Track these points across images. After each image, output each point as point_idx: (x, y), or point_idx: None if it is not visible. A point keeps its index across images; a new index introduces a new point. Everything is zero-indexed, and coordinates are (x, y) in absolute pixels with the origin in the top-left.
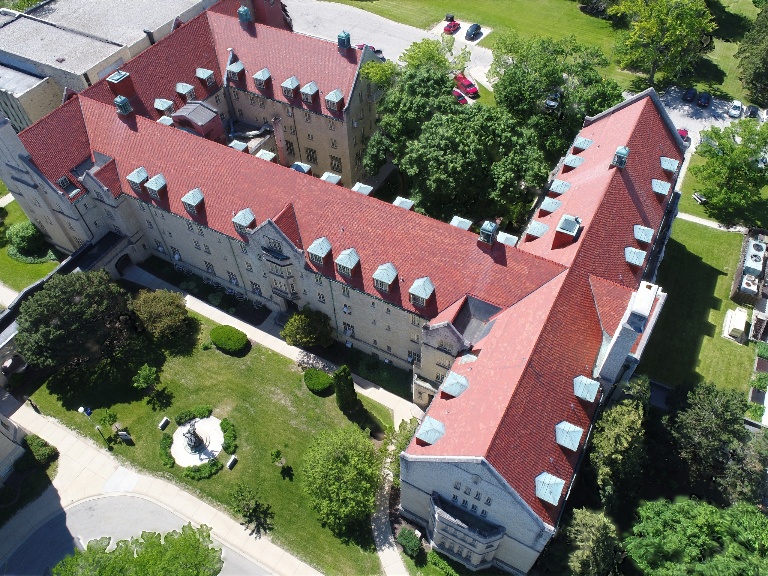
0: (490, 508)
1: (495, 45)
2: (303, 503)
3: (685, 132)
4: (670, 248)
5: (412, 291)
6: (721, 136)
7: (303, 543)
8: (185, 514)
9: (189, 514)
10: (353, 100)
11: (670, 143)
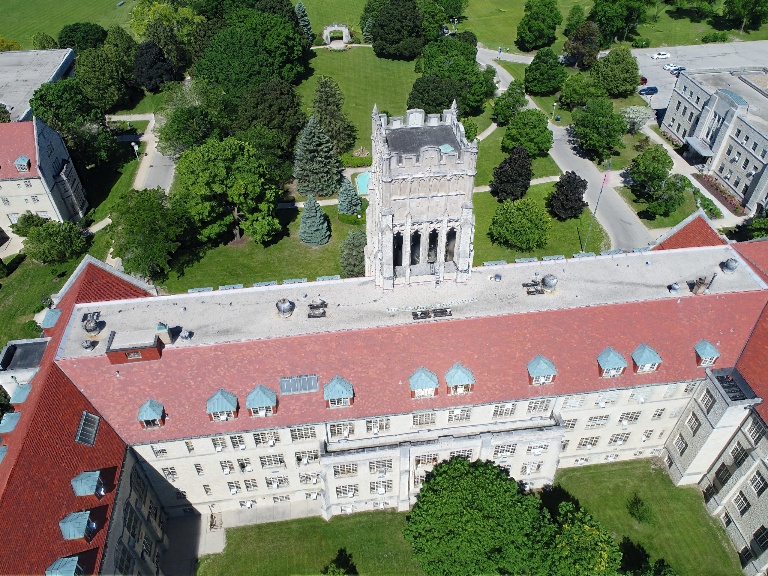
0: None
1: None
2: (78, 262)
3: None
4: None
5: None
6: None
7: (100, 253)
8: None
9: None
10: None
11: None
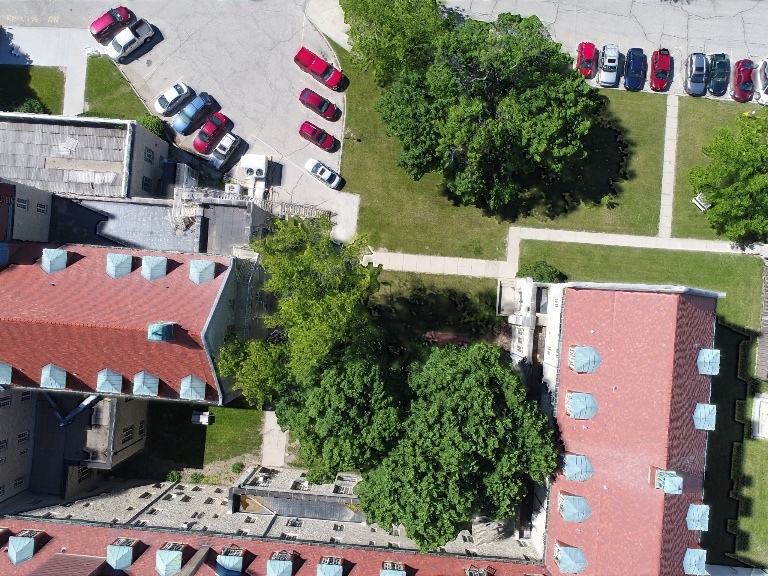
0: None
1: (352, 27)
2: None
3: (667, 62)
4: None
5: None
6: (744, 160)
7: None
8: None
9: None
10: (224, 381)
11: (703, 314)
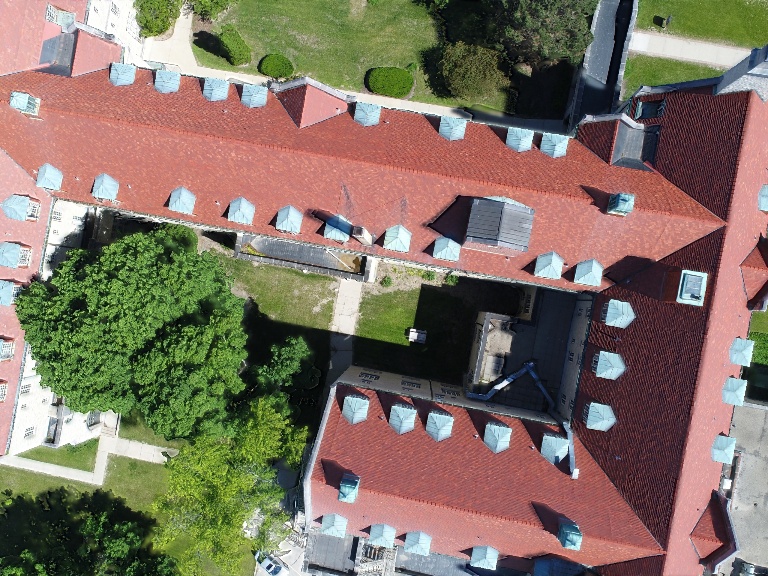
0: None
1: None
2: None
3: None
4: None
5: (131, 66)
6: None
7: None
8: None
9: None
10: None
11: None
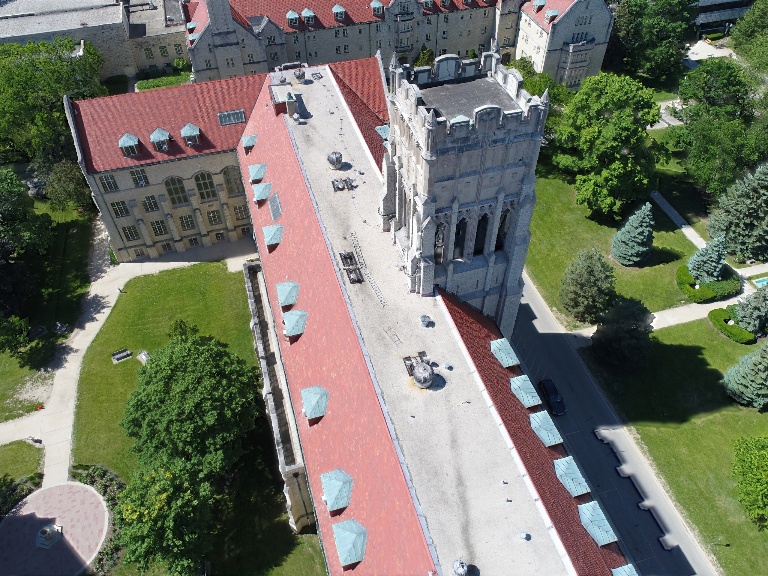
0: (590, 25)
1: None
2: None
3: None
4: None
5: None
6: None
7: None
8: None
9: None
10: None
11: None
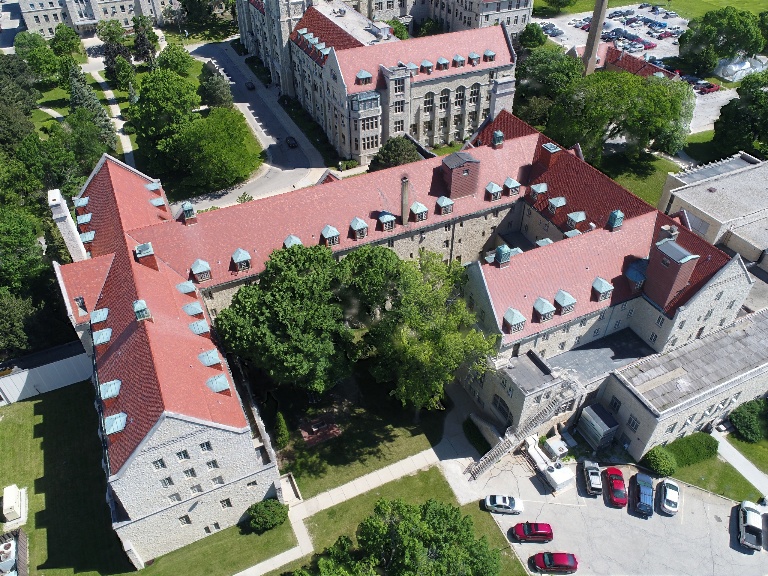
0: None
1: None
2: None
3: None
4: (118, 555)
5: None
6: None
7: None
8: (267, 194)
9: (265, 195)
10: None
11: None
